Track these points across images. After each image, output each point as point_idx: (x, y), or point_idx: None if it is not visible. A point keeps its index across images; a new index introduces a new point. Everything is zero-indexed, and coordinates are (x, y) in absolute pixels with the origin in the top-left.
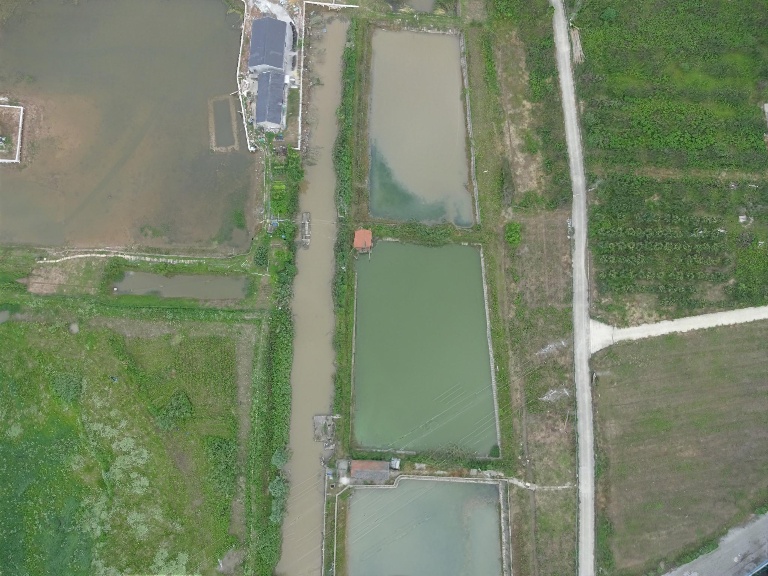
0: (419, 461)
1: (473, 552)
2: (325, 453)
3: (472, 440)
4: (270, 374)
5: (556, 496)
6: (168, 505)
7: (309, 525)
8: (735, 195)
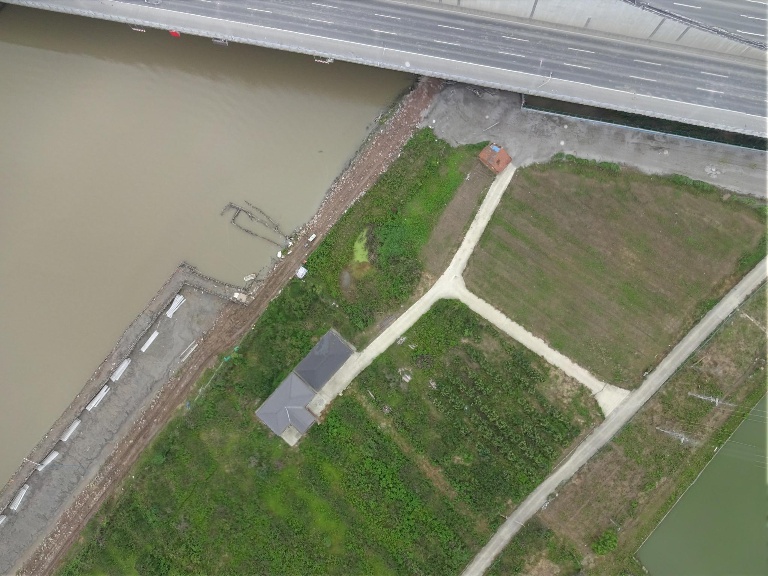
0: None
1: None
2: None
3: None
4: None
5: (761, 316)
6: None
7: None
8: (393, 401)
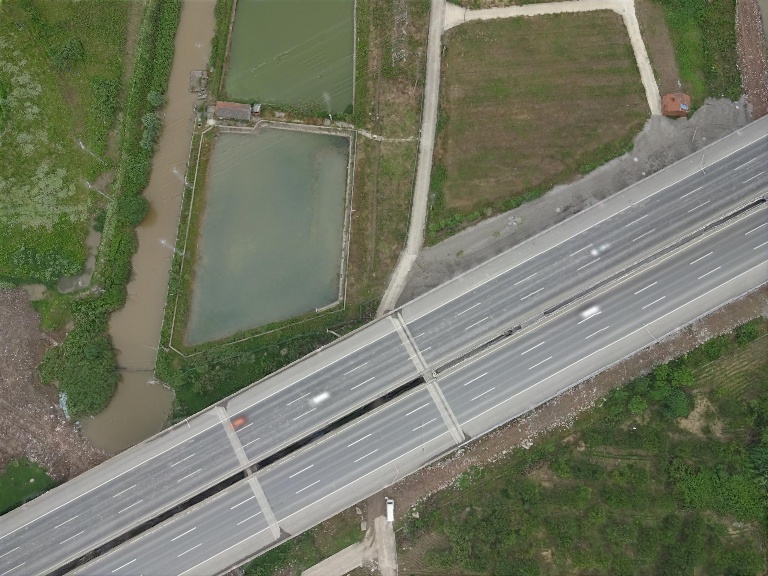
0: (278, 109)
1: (320, 192)
2: (198, 102)
3: (330, 99)
4: (155, 30)
5: (399, 147)
6: (54, 129)
7: (176, 158)
8: None
